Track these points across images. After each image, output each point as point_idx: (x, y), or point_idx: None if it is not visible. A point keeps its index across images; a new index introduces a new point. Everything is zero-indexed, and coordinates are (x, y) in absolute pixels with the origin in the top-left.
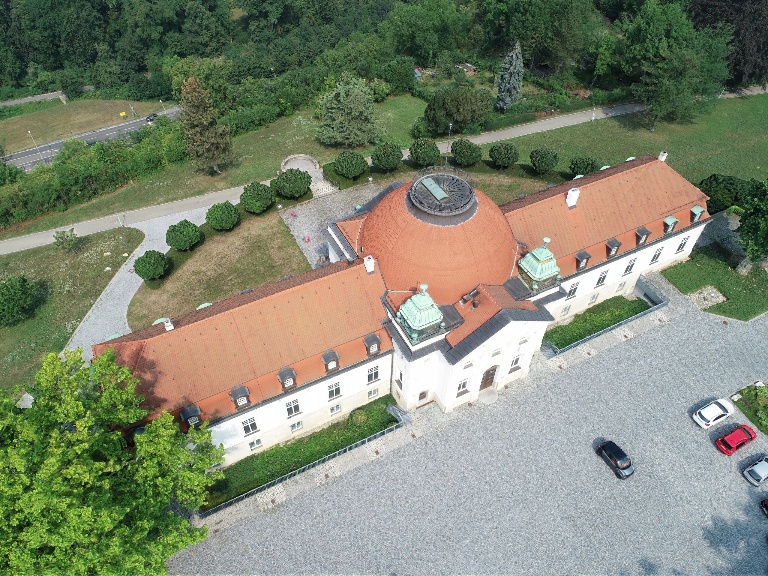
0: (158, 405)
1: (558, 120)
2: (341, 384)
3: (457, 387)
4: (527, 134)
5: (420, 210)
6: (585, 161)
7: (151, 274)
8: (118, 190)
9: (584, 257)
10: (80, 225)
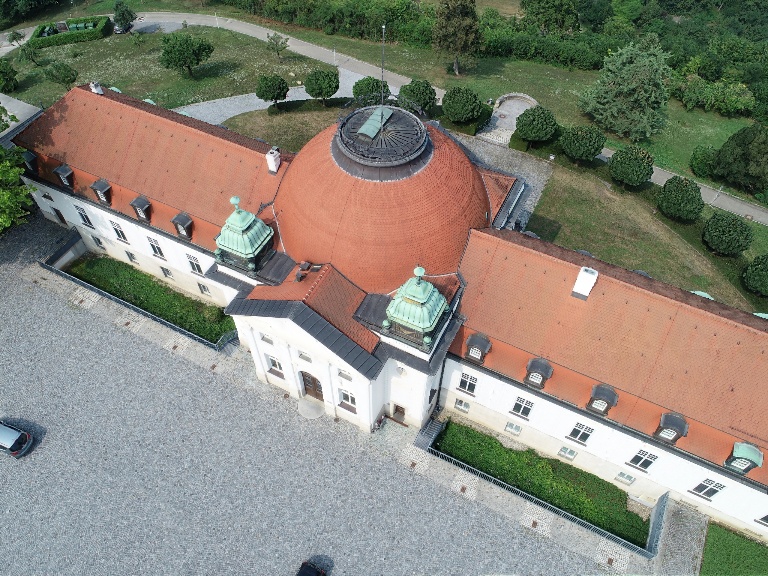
0: (47, 144)
1: None
2: (200, 263)
3: (264, 358)
4: None
5: None
6: None
7: (260, 94)
8: (379, 43)
9: (535, 368)
10: (317, 48)
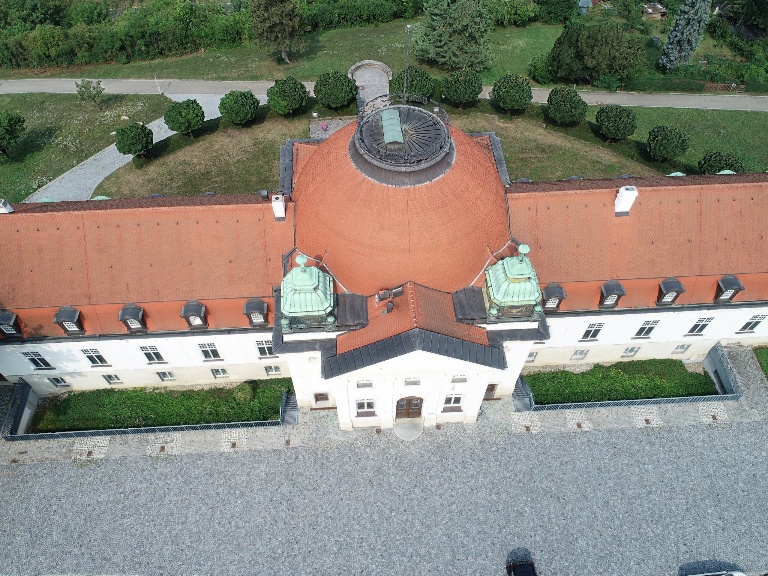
0: None
1: (736, 99)
2: (218, 347)
3: (354, 405)
4: (681, 107)
5: (358, 151)
6: (724, 159)
7: (126, 149)
8: (185, 56)
9: (612, 292)
10: (126, 82)
